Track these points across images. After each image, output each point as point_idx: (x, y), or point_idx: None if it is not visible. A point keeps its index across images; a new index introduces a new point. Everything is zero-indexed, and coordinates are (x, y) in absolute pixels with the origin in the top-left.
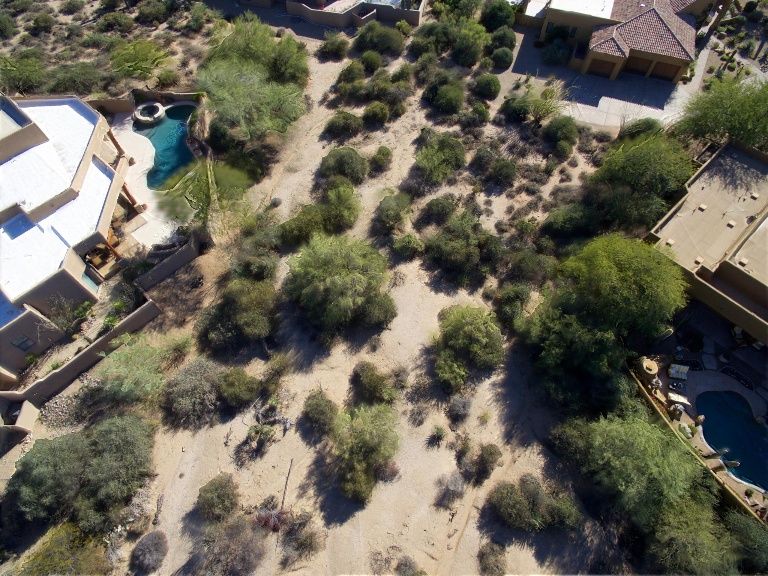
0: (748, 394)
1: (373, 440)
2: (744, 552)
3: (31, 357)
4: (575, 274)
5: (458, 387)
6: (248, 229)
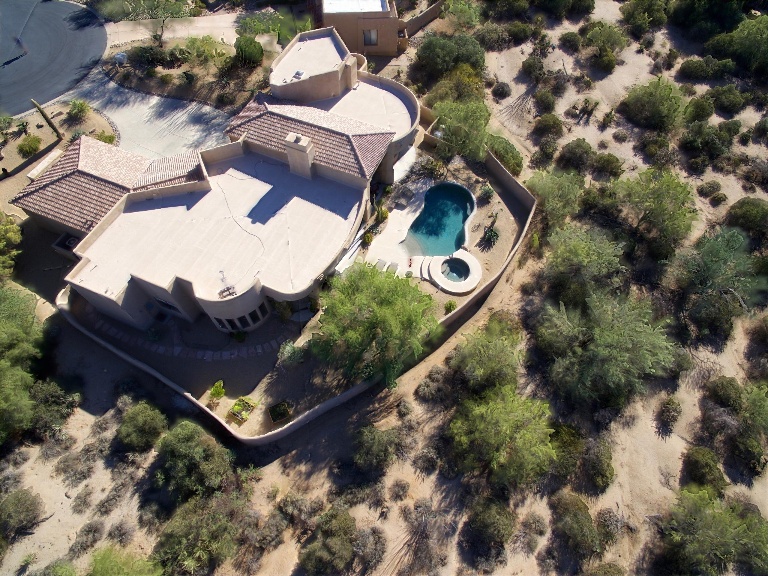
0: None
1: (616, 36)
2: None
3: (401, 9)
4: None
5: None
6: None
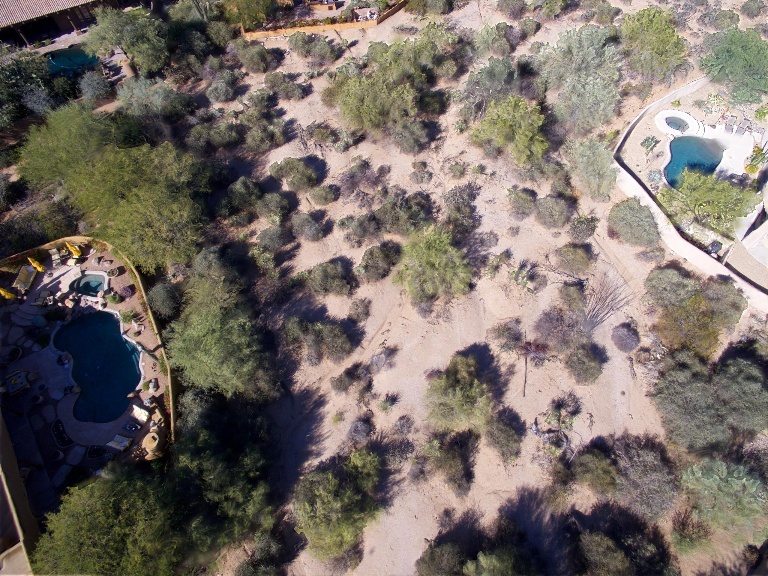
0: (67, 416)
1: None
2: (178, 290)
3: None
4: (173, 572)
5: None
6: None
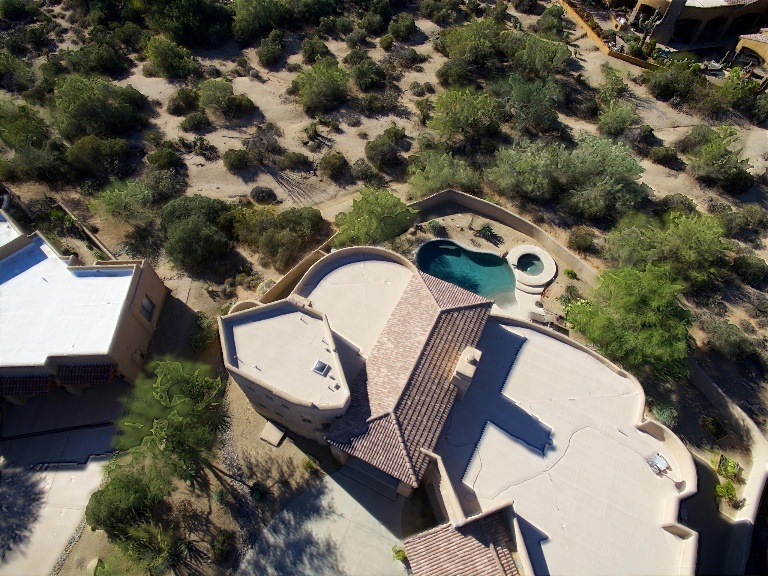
0: None
1: (220, 85)
2: None
3: None
4: None
5: (200, 72)
6: (6, 173)
